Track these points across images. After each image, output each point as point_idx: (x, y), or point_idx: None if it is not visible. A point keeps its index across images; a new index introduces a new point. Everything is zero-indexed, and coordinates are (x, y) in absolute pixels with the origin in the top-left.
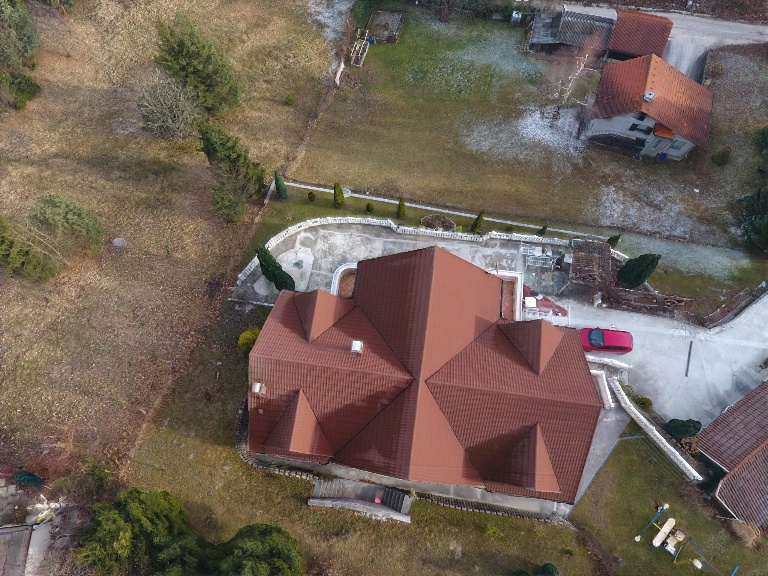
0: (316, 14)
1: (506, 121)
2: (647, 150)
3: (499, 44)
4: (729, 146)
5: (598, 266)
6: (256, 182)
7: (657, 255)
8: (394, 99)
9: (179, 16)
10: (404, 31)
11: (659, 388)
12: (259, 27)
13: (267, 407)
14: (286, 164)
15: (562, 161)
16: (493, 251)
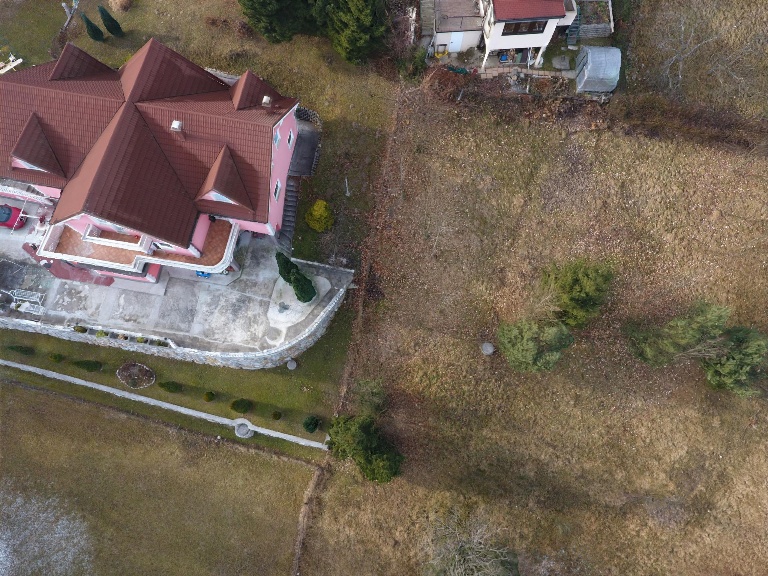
0: None
1: None
2: None
3: None
4: None
5: None
6: None
7: None
8: None
9: None
10: None
11: None
12: None
13: None
14: (320, 491)
15: None
16: (74, 314)
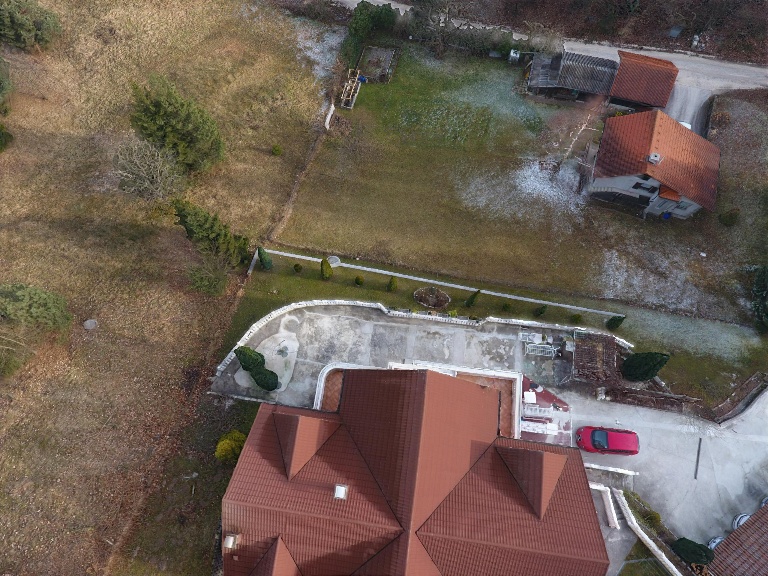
0: (305, 50)
1: (504, 173)
2: (651, 209)
3: (496, 85)
4: (737, 207)
5: (602, 362)
6: (238, 255)
7: (666, 356)
8: (386, 145)
9: (154, 78)
10: (397, 69)
11: (667, 493)
12: (245, 65)
13: (243, 553)
14: (272, 226)
15: (562, 220)
16: (490, 336)
